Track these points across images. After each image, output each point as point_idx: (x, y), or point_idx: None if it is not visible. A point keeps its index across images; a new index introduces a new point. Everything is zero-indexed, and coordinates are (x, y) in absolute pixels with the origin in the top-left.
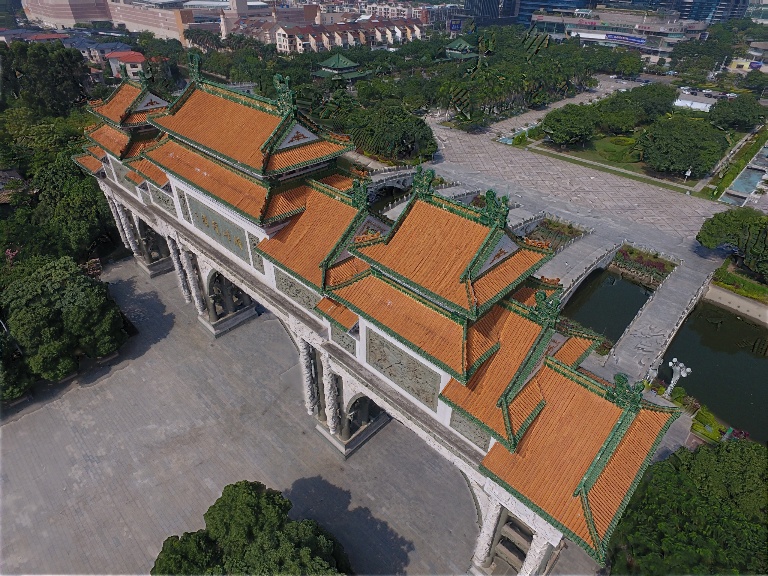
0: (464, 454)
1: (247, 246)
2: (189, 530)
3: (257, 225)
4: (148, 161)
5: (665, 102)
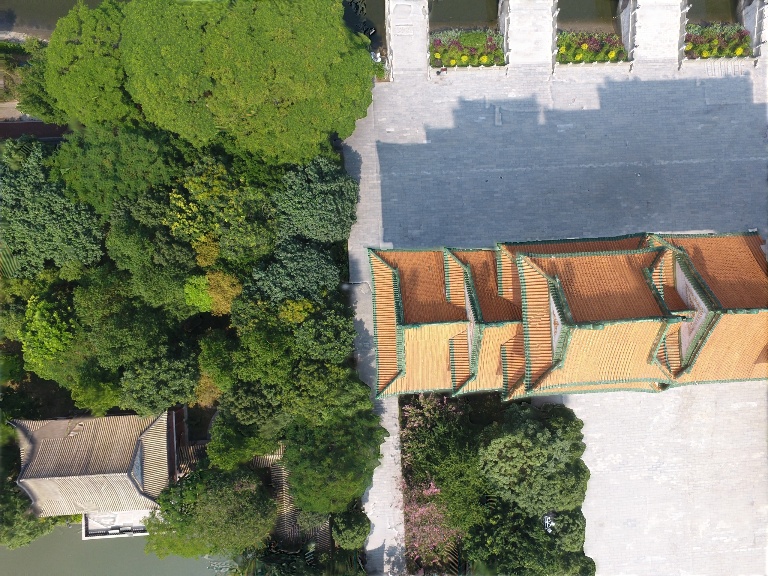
0: None
1: None
2: (760, 432)
3: None
4: (701, 366)
5: None
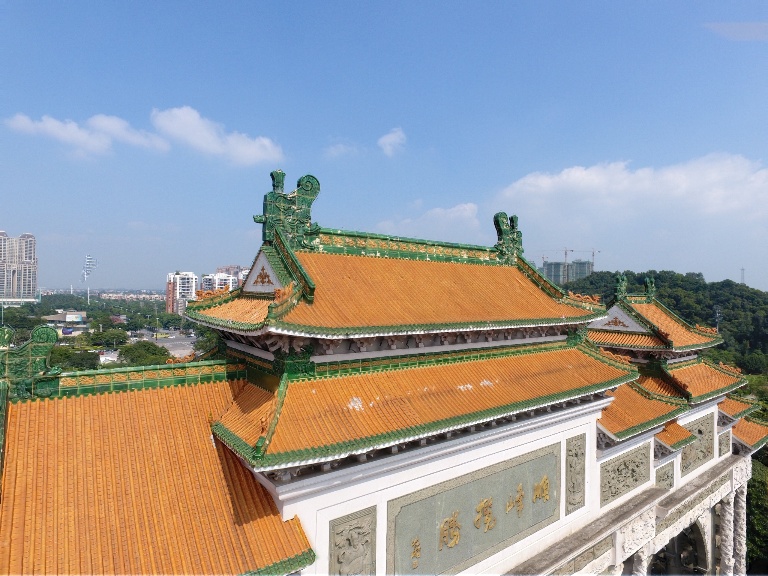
0: (739, 461)
1: (560, 477)
2: None
3: (603, 399)
4: None
5: (93, 356)
